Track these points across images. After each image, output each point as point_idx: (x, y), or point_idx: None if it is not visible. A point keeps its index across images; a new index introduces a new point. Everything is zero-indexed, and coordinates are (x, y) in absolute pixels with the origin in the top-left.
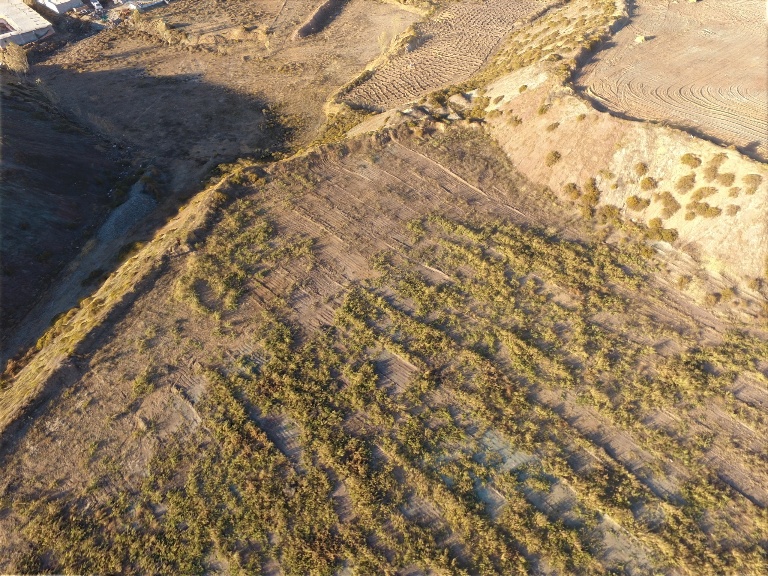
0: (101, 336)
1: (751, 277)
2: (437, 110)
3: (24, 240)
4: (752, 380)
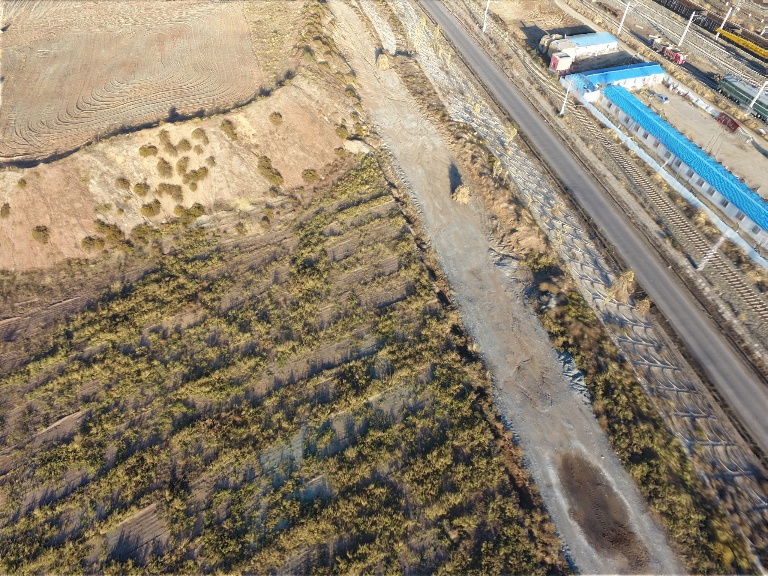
0: None
1: (266, 191)
2: None
3: None
4: (332, 245)
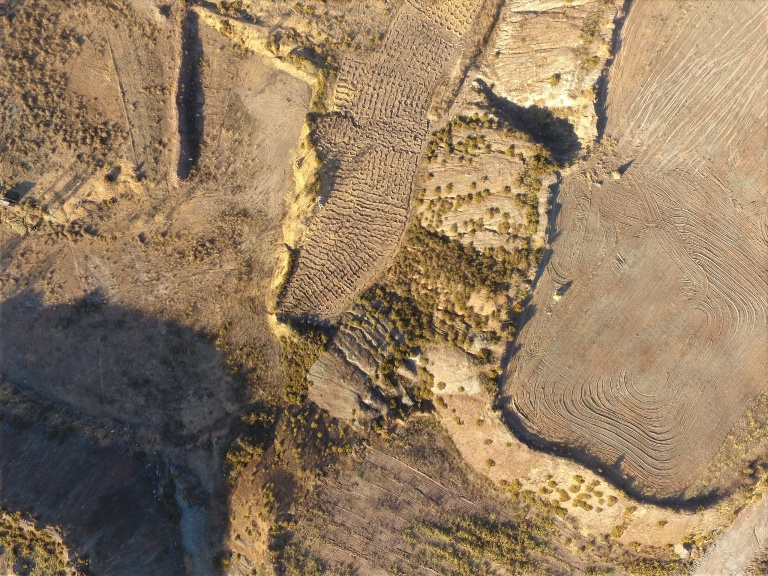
0: None
1: (603, 535)
2: (391, 391)
3: None
4: None
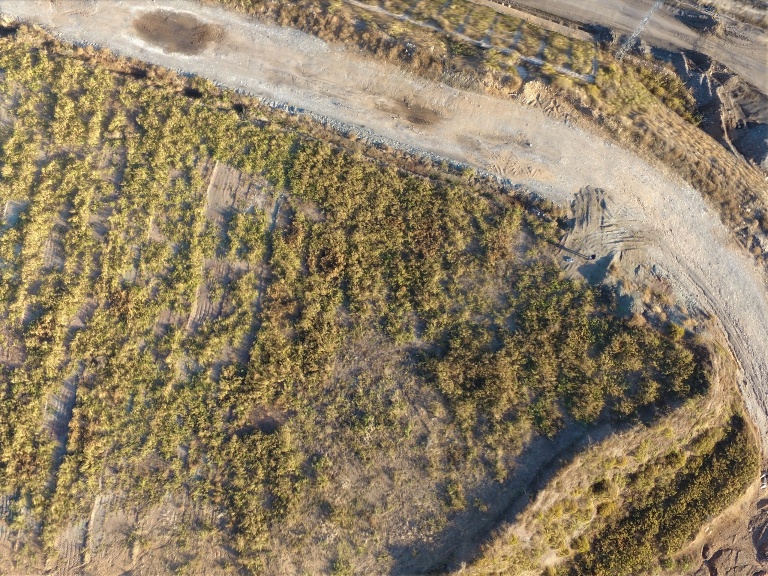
0: None
1: None
2: None
3: None
4: None
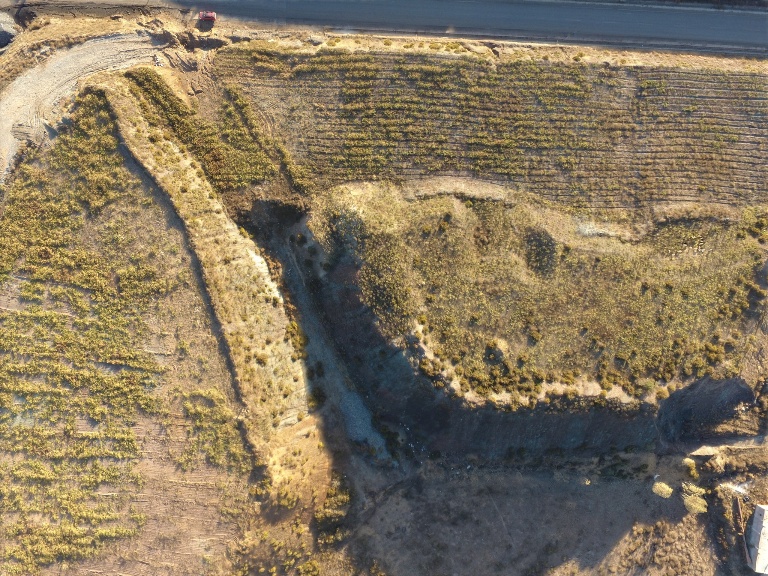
0: (225, 350)
1: None
2: None
3: (372, 361)
4: None
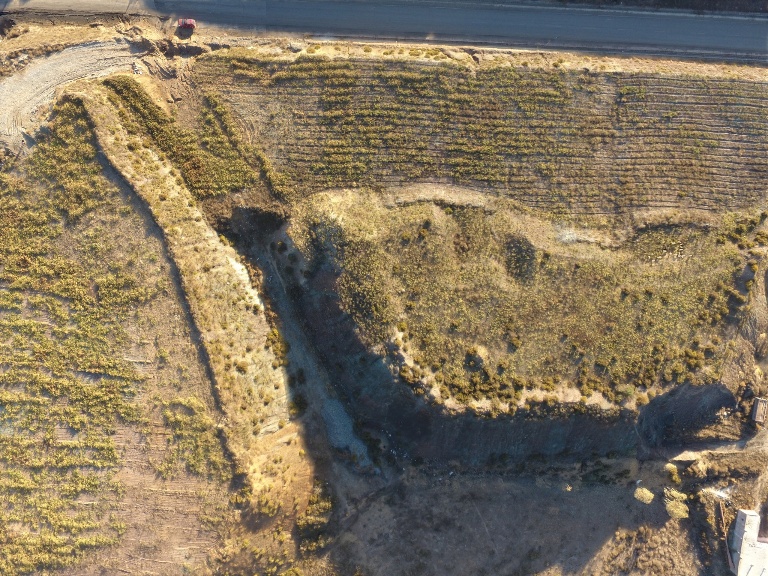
0: (204, 358)
1: None
2: None
3: (352, 368)
4: None
